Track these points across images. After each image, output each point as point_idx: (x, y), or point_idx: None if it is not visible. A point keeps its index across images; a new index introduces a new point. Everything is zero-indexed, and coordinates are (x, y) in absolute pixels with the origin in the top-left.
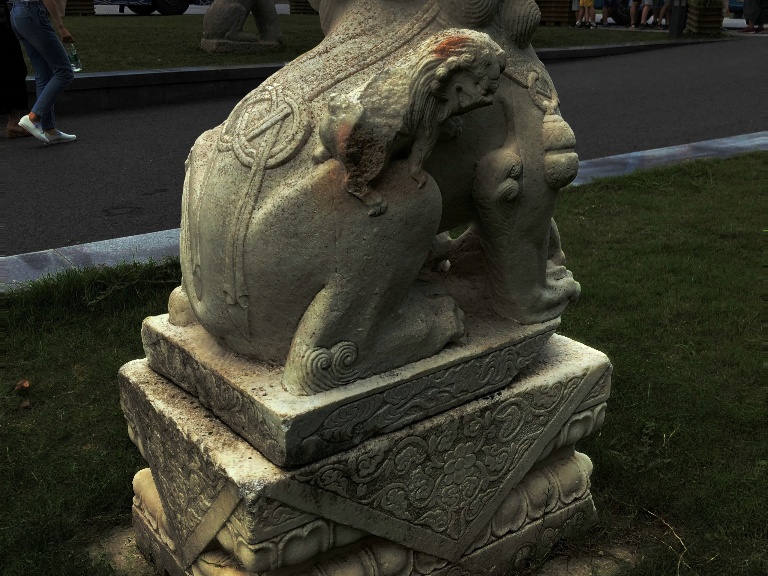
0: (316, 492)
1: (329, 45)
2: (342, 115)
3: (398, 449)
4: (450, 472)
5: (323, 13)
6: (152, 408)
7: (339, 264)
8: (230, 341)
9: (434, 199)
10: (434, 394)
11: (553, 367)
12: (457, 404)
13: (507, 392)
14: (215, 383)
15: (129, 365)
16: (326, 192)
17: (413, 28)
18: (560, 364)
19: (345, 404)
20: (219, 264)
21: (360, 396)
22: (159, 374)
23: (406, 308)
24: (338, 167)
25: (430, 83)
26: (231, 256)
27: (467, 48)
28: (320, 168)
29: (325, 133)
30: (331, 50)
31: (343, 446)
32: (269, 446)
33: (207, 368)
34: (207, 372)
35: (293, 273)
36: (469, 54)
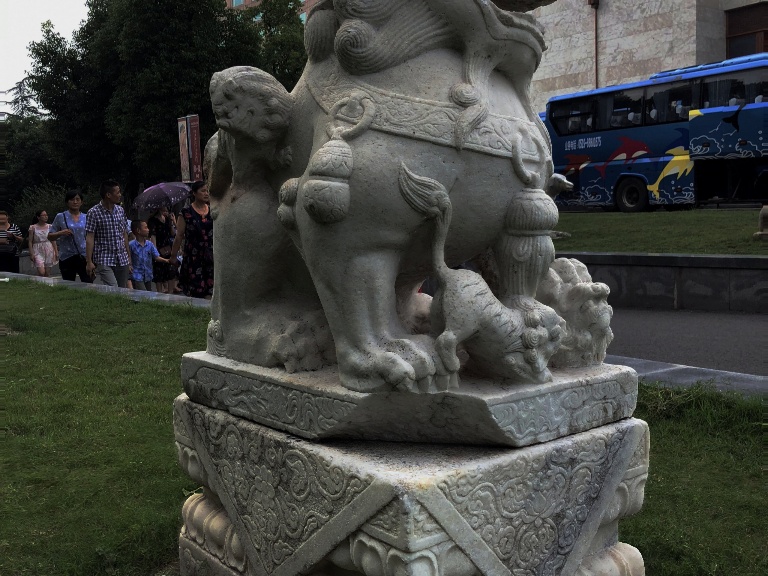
0: (193, 426)
1: None
2: None
3: (228, 430)
4: (259, 489)
5: None
6: None
7: None
8: None
9: (240, 214)
10: (255, 401)
11: (367, 459)
12: (273, 426)
13: (302, 443)
14: None
15: None
16: None
17: None
18: (377, 462)
19: (205, 366)
20: None
21: (211, 365)
22: None
23: (257, 313)
24: None
25: None
26: None
27: None
28: None
29: None
30: None
31: (207, 402)
32: None
33: None
34: None
35: None
36: None
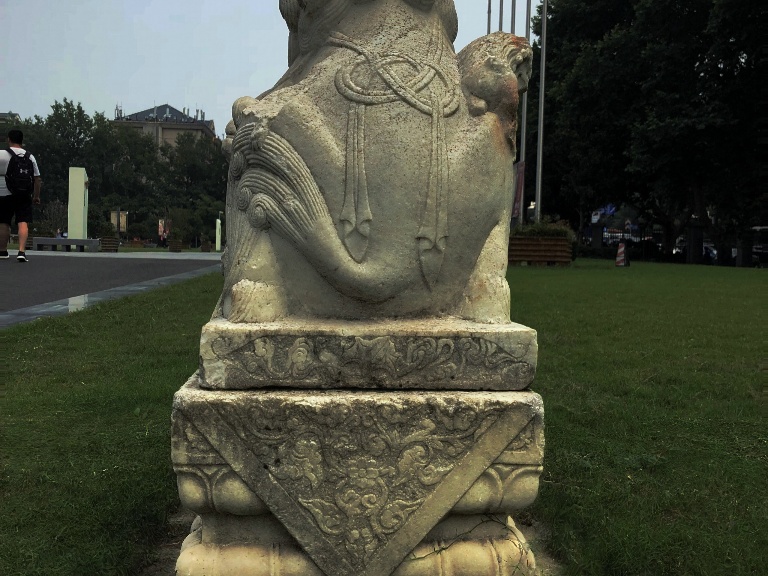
0: None
1: (400, 31)
2: (507, 73)
3: None
4: None
5: (336, 11)
6: (303, 409)
7: (506, 202)
8: (401, 299)
9: None
10: None
11: None
12: None
13: None
14: (394, 347)
15: (190, 393)
16: (498, 137)
17: (439, 33)
18: None
19: None
20: (414, 209)
21: None
22: (244, 389)
23: None
24: (498, 118)
25: (512, 66)
26: (435, 196)
27: (527, 45)
28: (487, 118)
29: (492, 87)
30: (407, 35)
31: None
32: (507, 374)
33: (380, 335)
34: (378, 340)
35: (486, 209)
36: (529, 49)
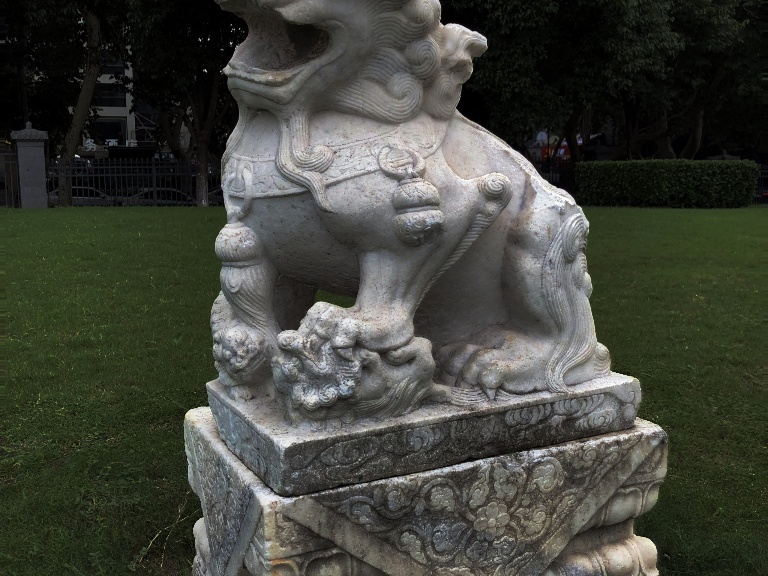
0: None
1: None
2: None
3: None
4: None
5: None
6: None
7: None
8: None
9: None
10: None
11: None
12: None
13: None
14: None
15: (654, 425)
16: None
17: None
18: None
19: None
20: None
21: None
22: None
23: None
24: None
25: None
26: None
27: None
28: None
29: None
30: None
31: None
32: None
33: None
34: None
35: None
36: None
